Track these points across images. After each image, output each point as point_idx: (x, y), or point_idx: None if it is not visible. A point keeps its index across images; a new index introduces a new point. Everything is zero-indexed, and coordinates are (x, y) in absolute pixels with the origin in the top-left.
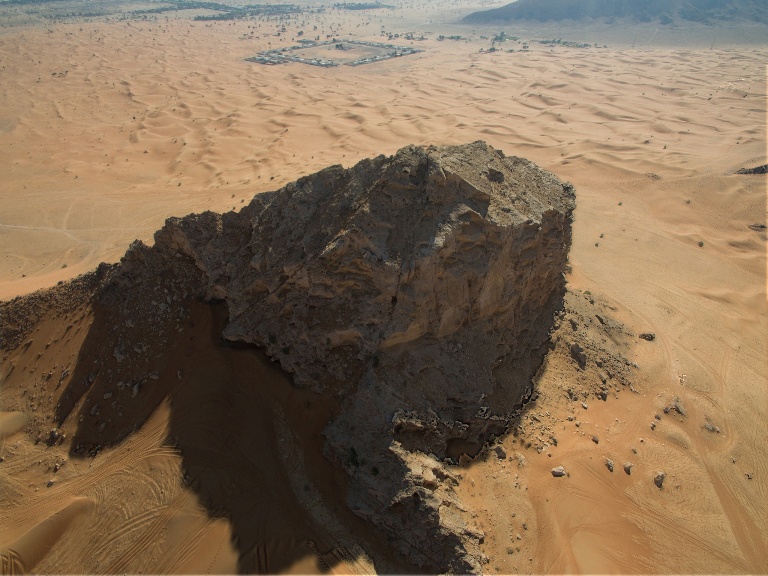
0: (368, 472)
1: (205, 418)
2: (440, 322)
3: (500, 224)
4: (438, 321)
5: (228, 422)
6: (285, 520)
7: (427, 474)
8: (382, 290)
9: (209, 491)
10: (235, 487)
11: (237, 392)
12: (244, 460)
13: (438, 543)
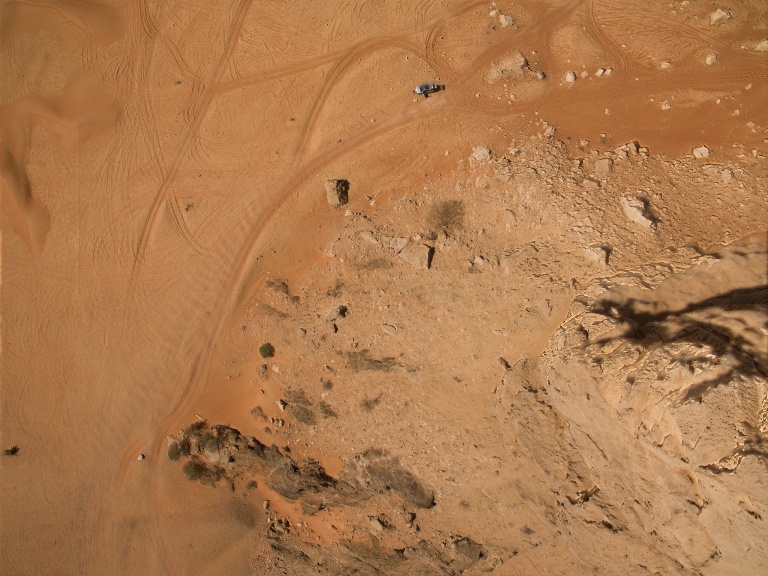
0: None
1: None
2: None
3: None
4: None
5: None
6: None
7: None
8: None
9: None
10: None
11: None
12: None
13: None
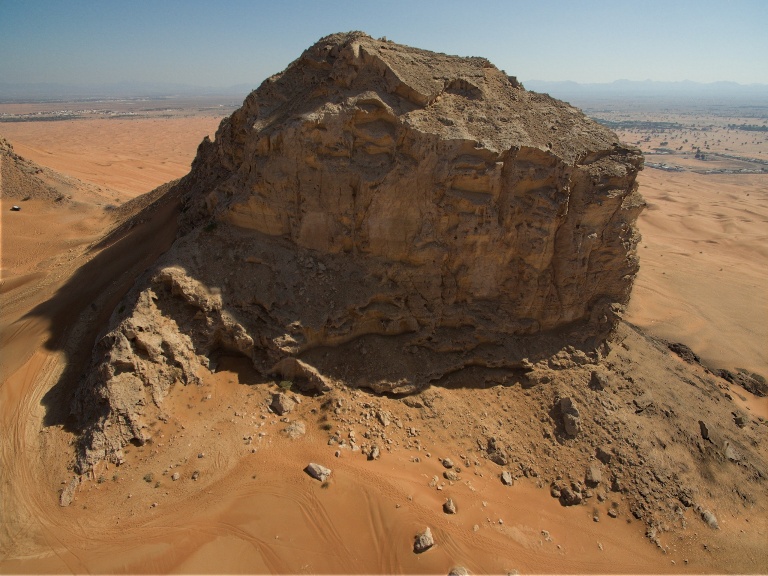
0: (118, 307)
1: (121, 246)
2: (301, 222)
3: (415, 127)
4: (300, 220)
5: (125, 252)
6: (56, 314)
7: (149, 336)
8: (246, 157)
9: (67, 284)
10: (74, 286)
11: (152, 238)
12: (98, 274)
13: (94, 400)
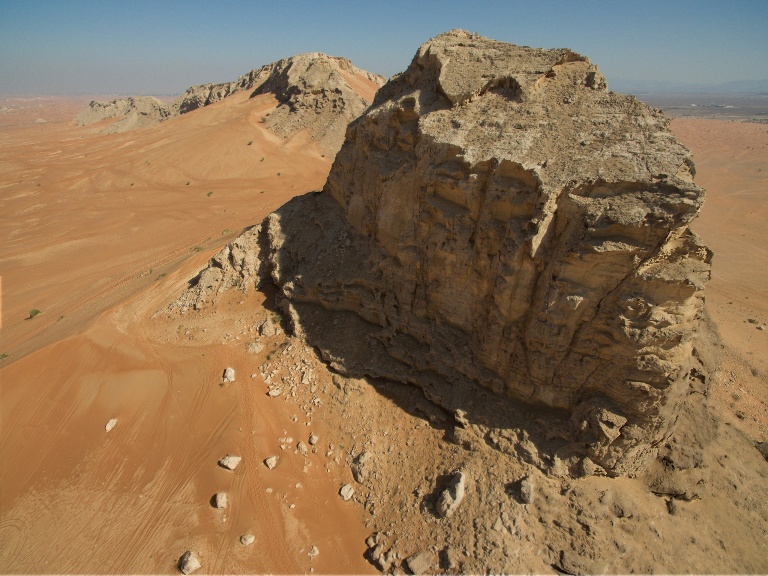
0: None
1: None
2: (350, 202)
3: (423, 127)
4: None
5: None
6: None
7: (239, 252)
8: None
9: None
10: None
11: None
12: None
13: None
